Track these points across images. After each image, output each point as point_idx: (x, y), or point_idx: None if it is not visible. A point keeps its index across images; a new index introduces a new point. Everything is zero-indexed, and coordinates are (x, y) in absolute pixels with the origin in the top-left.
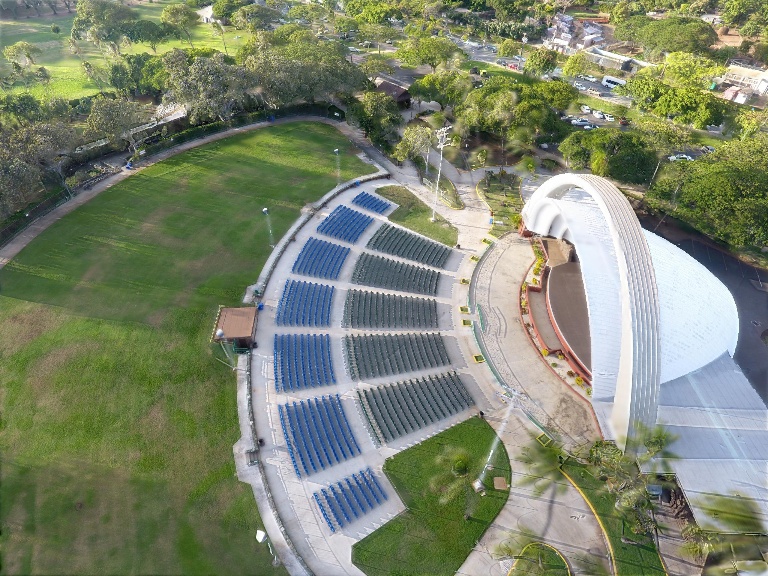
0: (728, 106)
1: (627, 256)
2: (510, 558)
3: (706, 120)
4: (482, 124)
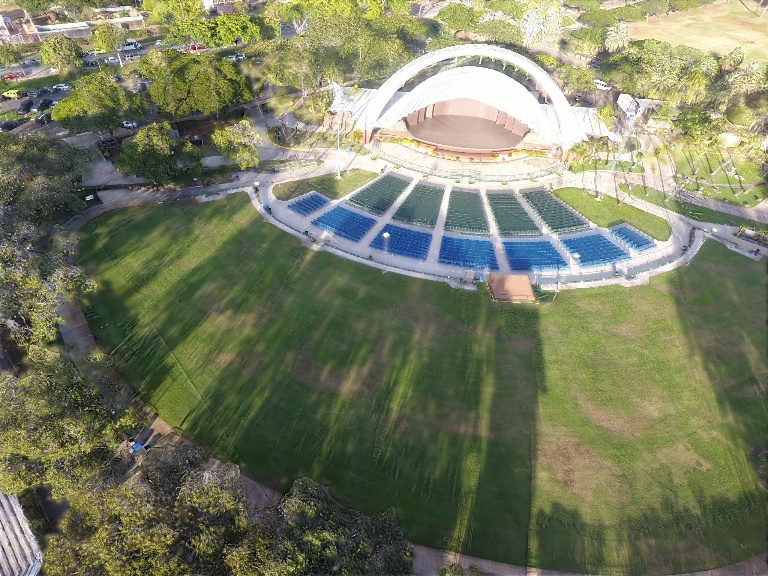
0: None
1: (528, 62)
2: (631, 197)
3: (259, 31)
4: (225, 102)
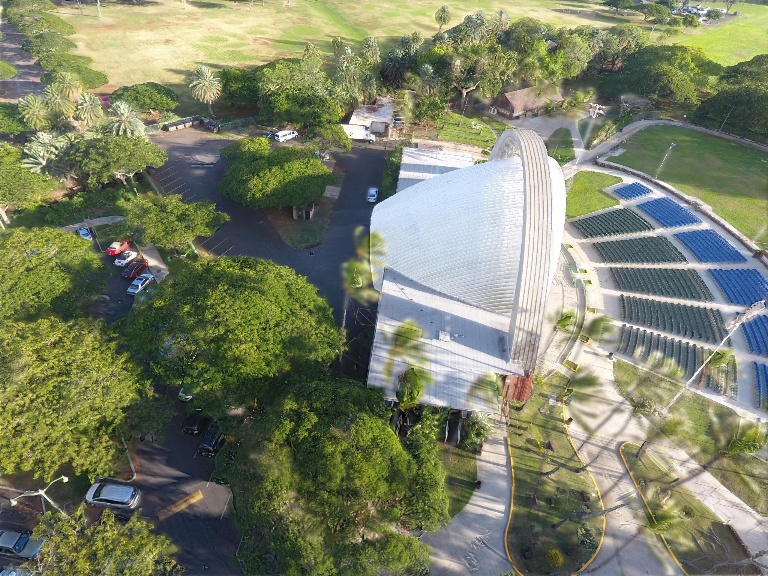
0: None
1: None
2: None
3: None
4: None
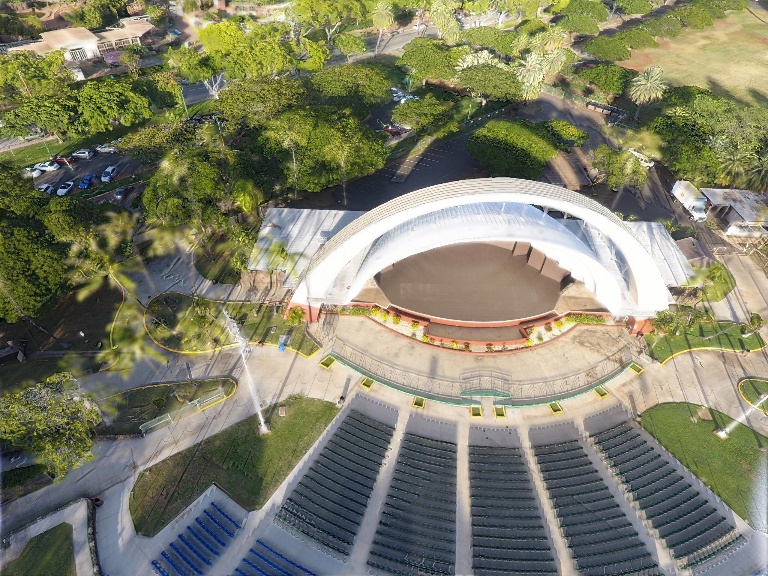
0: None
1: (590, 208)
2: None
3: (148, 104)
4: (48, 292)
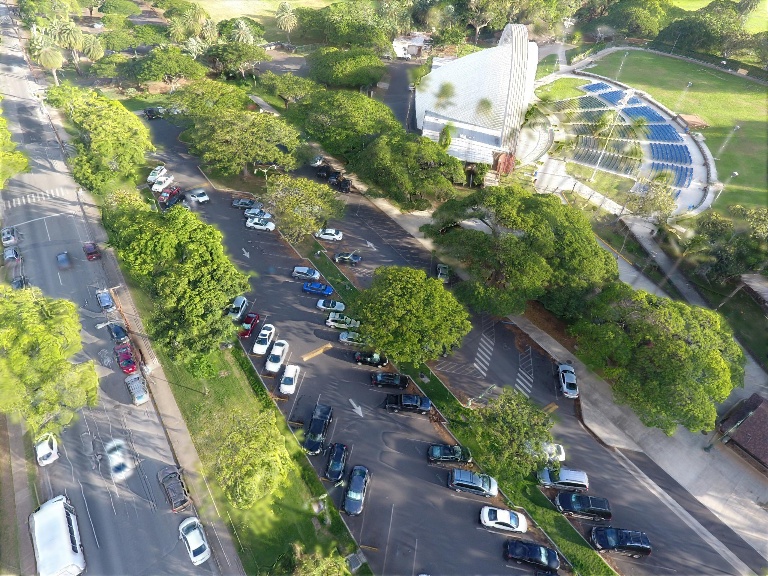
0: (130, 216)
1: None
2: None
3: None
4: None
